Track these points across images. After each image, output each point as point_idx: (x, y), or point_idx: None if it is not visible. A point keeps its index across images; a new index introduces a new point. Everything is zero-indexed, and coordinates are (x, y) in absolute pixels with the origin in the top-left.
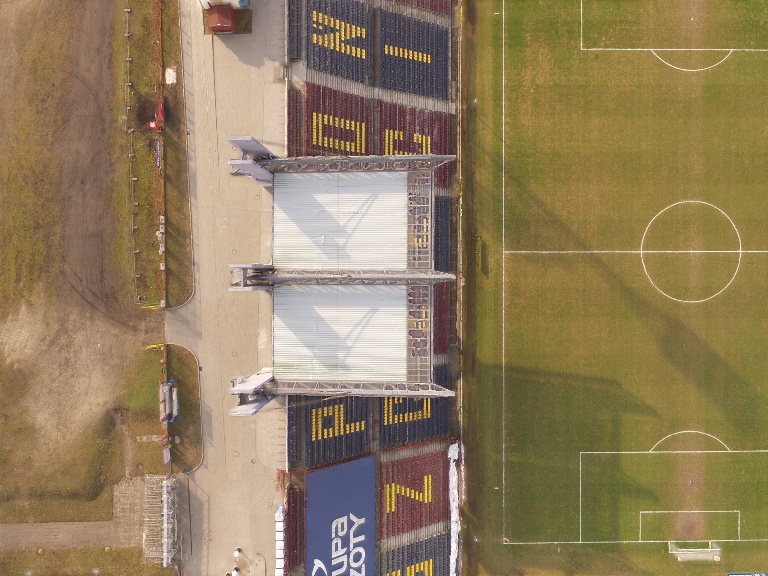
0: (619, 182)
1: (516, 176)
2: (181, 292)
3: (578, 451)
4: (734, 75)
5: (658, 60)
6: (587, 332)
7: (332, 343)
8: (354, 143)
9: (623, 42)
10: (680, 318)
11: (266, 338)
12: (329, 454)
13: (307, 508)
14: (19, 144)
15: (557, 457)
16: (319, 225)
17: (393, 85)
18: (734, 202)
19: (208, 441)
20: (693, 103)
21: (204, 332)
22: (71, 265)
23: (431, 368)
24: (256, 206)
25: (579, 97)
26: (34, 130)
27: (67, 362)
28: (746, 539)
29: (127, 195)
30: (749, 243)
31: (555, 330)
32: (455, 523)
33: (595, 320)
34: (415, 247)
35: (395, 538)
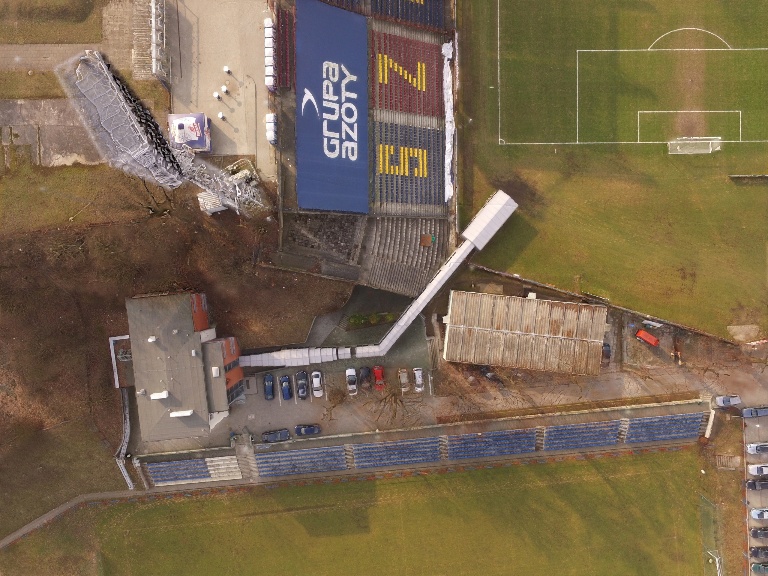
0: None
1: None
2: None
3: (574, 49)
4: None
5: None
6: None
7: None
8: None
9: None
10: None
11: None
12: None
13: (297, 30)
14: None
15: (553, 55)
16: None
17: None
18: None
19: None
20: None
21: None
22: None
23: None
24: None
25: None
26: None
27: None
28: (748, 140)
29: None
30: None
31: None
32: (450, 123)
33: None
34: None
35: (388, 113)
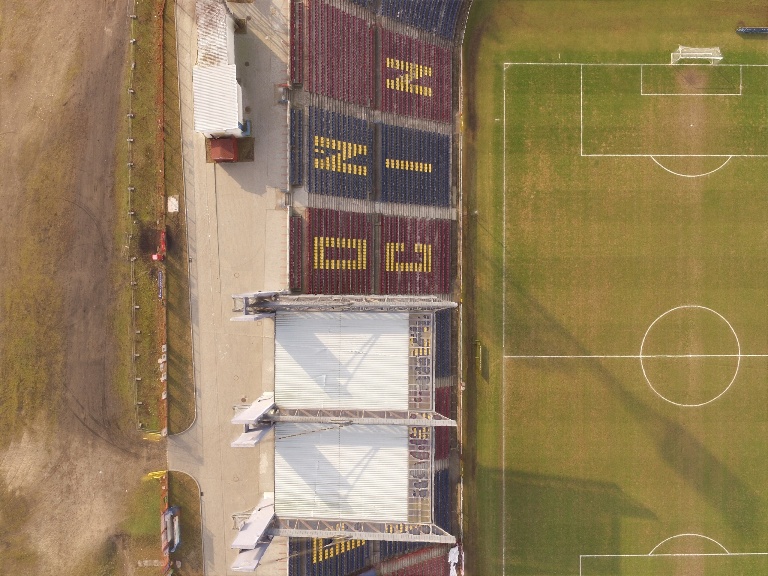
0: (619, 287)
1: (516, 281)
2: (183, 419)
3: (578, 554)
4: (733, 181)
5: (658, 166)
6: (587, 436)
7: (333, 481)
8: (355, 260)
9: (623, 148)
10: (679, 422)
11: (267, 463)
12: (330, 574)
13: None
14: (21, 273)
15: (557, 560)
16: (321, 364)
17: (394, 198)
18: (733, 307)
19: (209, 566)
20: (692, 209)
21: (206, 458)
22: (73, 393)
23: (432, 509)
24: (258, 332)
25: (579, 203)
26: (36, 259)
27: (69, 489)
28: None
29: (129, 323)
30: (748, 347)
31: (555, 434)
32: None
33: (595, 424)
34: (416, 388)
35: None
